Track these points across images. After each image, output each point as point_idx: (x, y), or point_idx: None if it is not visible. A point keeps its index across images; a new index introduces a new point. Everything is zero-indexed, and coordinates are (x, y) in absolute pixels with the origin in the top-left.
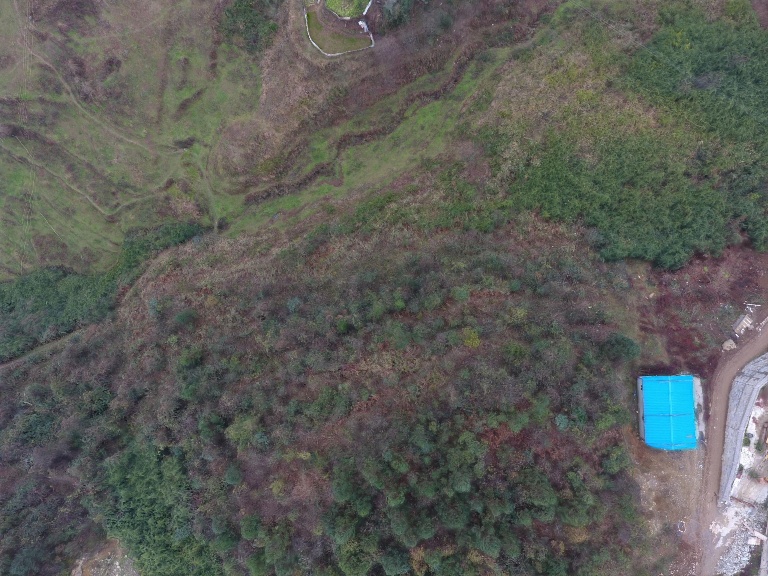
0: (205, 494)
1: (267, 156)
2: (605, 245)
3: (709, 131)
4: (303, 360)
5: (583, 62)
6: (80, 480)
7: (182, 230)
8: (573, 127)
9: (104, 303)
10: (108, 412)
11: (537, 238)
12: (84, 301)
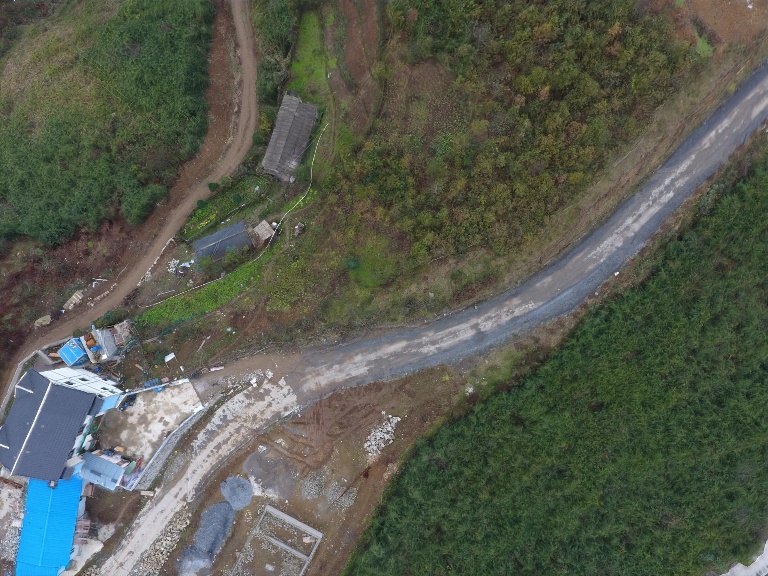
0: None
1: None
2: None
3: (124, 102)
4: None
5: (67, 36)
6: None
7: None
8: (28, 102)
9: None
10: None
11: None
12: None
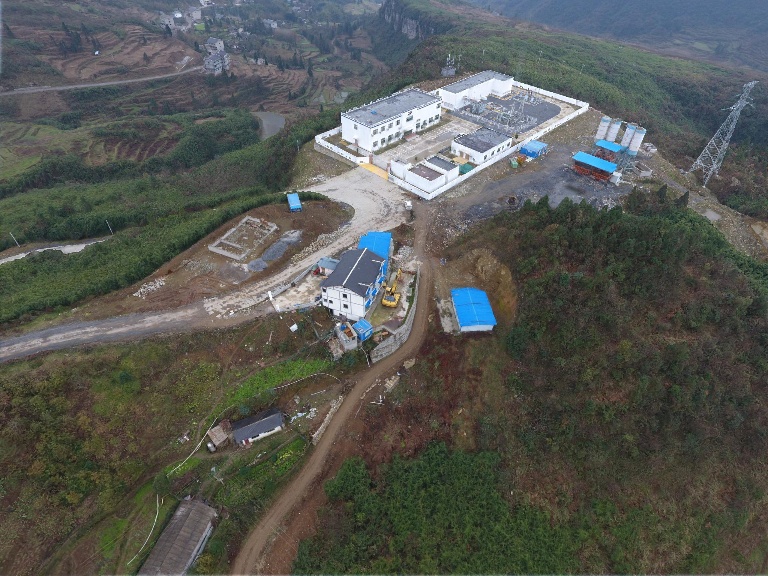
0: None
1: None
2: None
3: None
4: (723, 351)
5: None
6: None
7: None
8: None
9: None
10: None
11: None
12: None
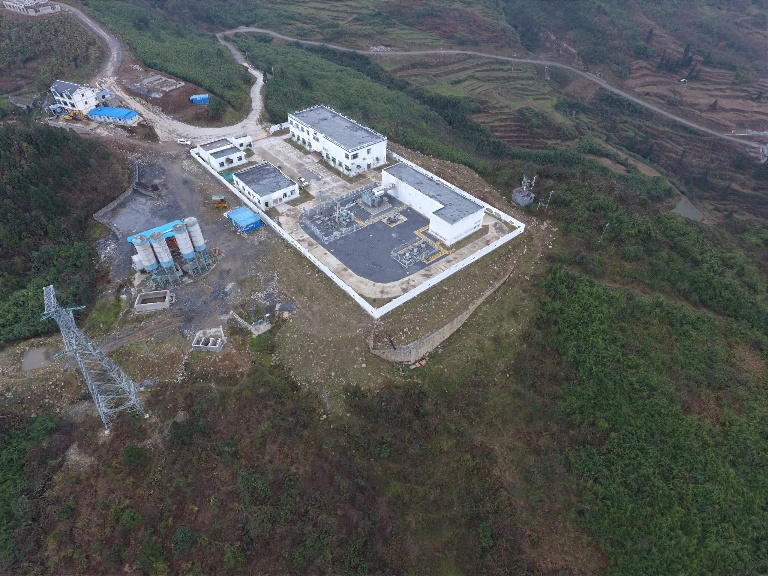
0: None
1: None
2: None
3: None
4: None
5: None
6: None
7: None
8: None
9: None
10: None
11: None
12: None
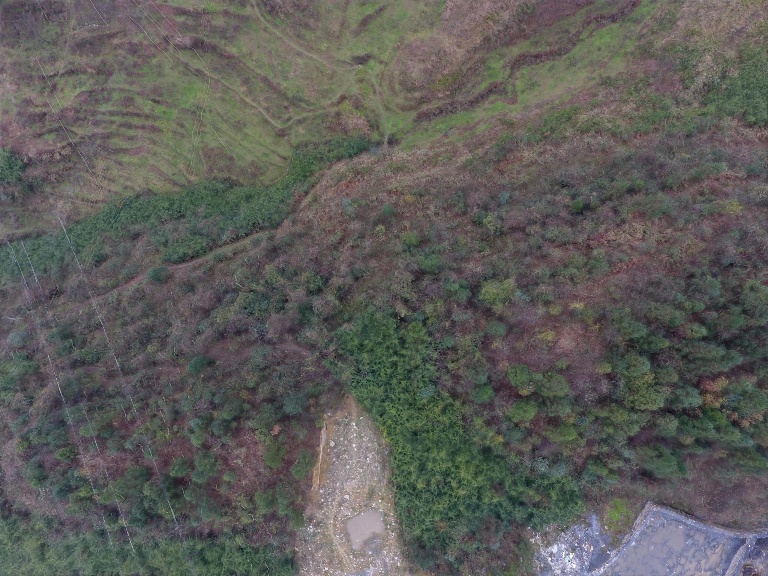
0: (459, 351)
1: (446, 72)
2: None
3: None
4: (543, 234)
5: None
6: (319, 344)
7: (356, 143)
8: None
9: (283, 208)
10: (327, 291)
11: (744, 141)
12: (260, 207)
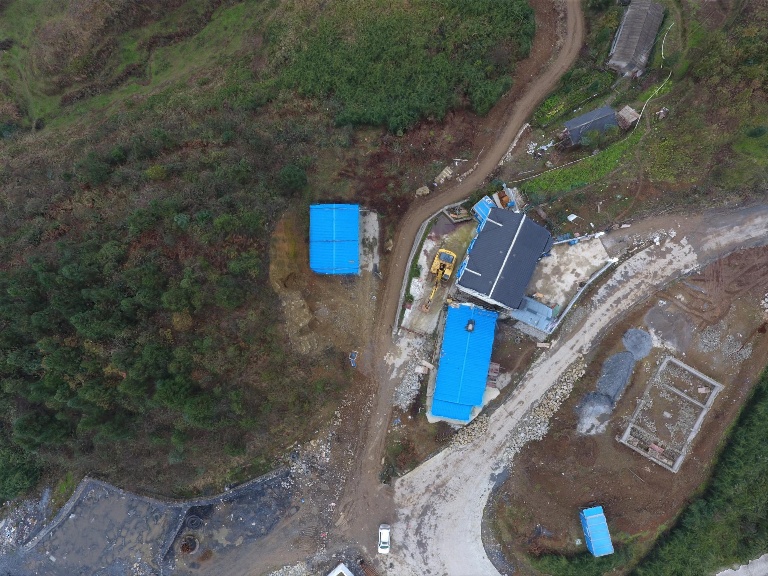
0: None
1: (76, 54)
2: (340, 112)
3: (451, 8)
4: (23, 206)
5: None
6: None
7: None
8: (338, 12)
9: None
10: None
11: (289, 112)
12: None
